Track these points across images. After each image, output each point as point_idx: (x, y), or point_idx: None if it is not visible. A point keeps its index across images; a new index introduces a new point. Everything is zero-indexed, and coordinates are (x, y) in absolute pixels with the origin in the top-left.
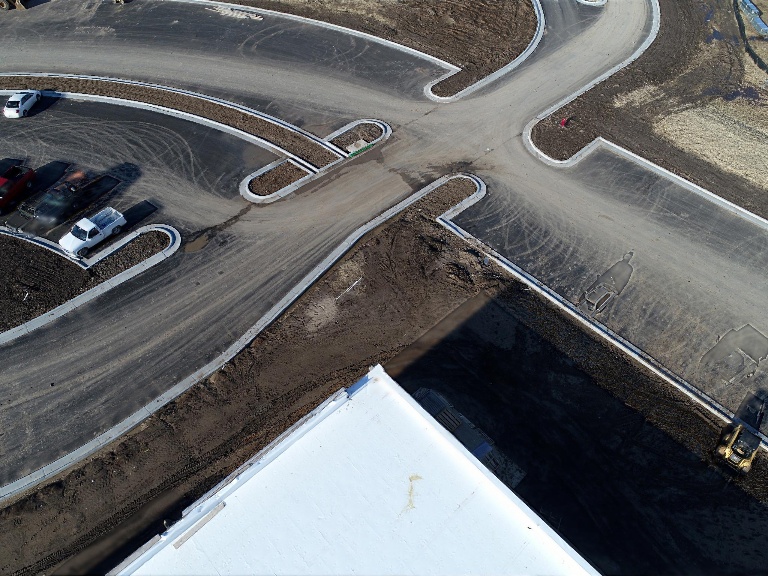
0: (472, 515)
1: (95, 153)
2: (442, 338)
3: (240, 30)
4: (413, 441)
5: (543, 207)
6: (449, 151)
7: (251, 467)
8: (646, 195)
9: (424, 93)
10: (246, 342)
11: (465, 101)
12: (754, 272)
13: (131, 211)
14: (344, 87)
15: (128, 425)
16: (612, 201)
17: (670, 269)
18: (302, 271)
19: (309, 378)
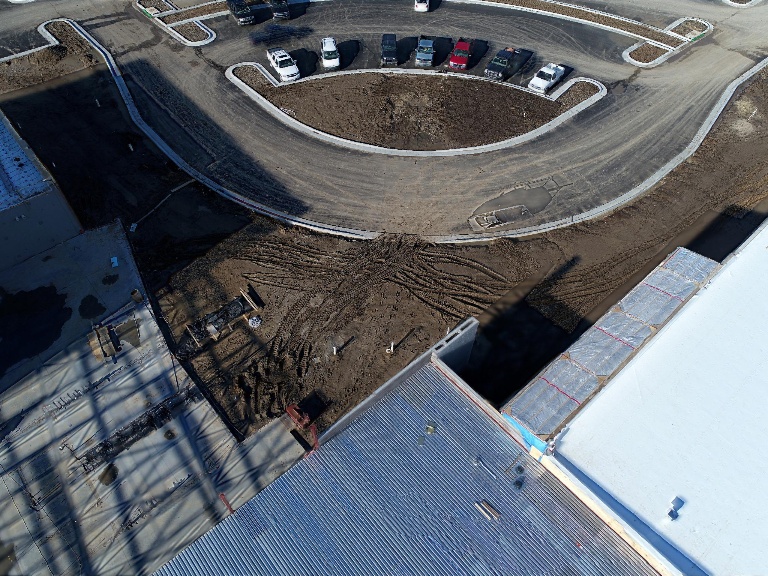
0: None
1: (500, 35)
2: None
3: None
4: None
5: None
6: (767, 38)
7: None
8: None
9: (723, 1)
10: (700, 142)
11: (759, 7)
12: None
13: None
14: None
15: (653, 181)
16: None
17: None
18: (708, 106)
19: (761, 160)
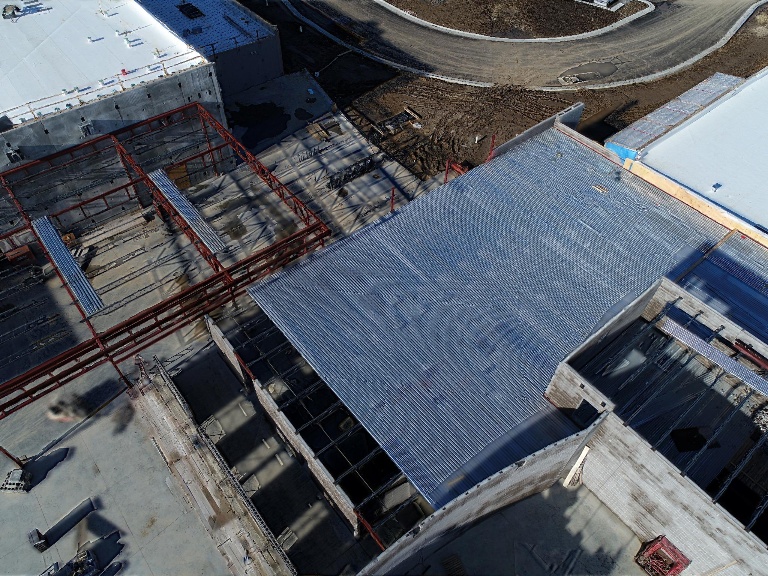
0: None
1: None
2: None
3: None
4: None
5: None
6: None
7: None
8: None
9: None
10: (728, 39)
11: None
12: None
13: None
14: None
15: None
16: None
17: None
18: (734, 18)
19: None
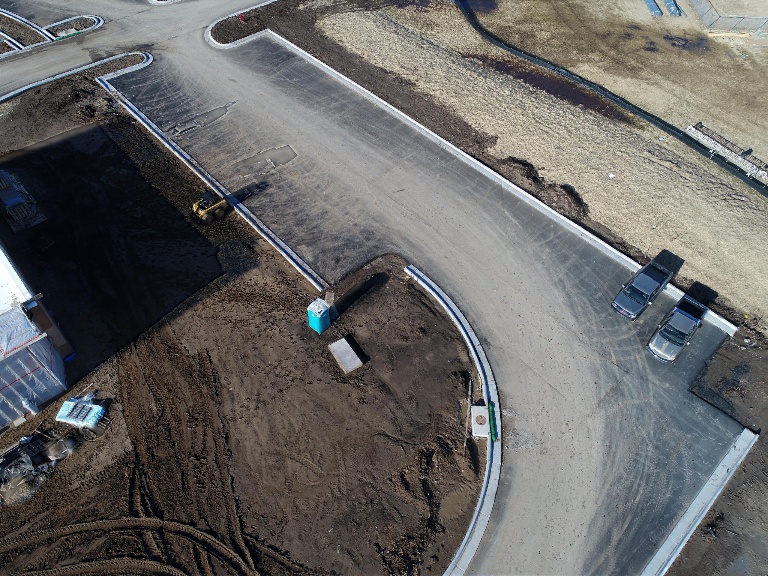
0: None
1: None
2: (43, 147)
3: None
4: None
5: (188, 74)
6: (140, 37)
7: None
8: (275, 67)
9: None
10: None
11: (177, 4)
12: (320, 115)
13: None
14: None
15: None
16: (245, 70)
17: (256, 112)
18: None
19: None
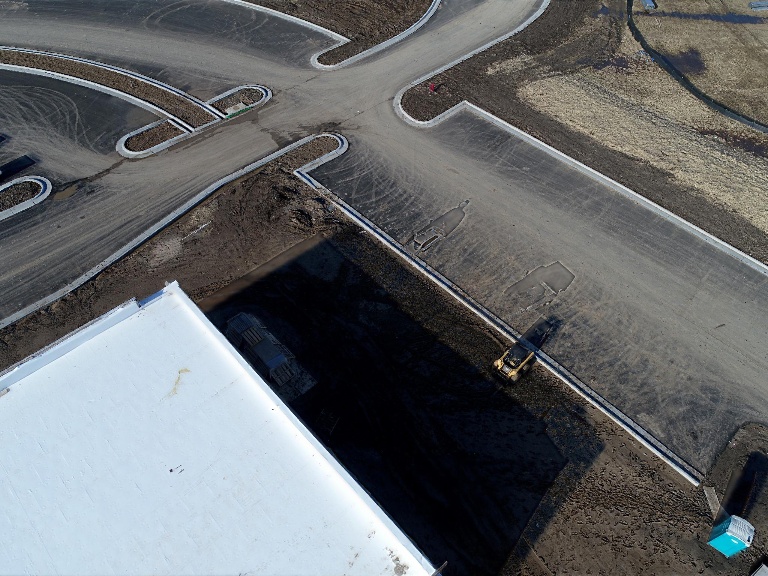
0: (226, 400)
1: None
2: (271, 272)
3: (148, 5)
4: (191, 342)
5: (397, 162)
6: (321, 113)
7: (33, 359)
8: (495, 151)
9: (310, 62)
10: (91, 275)
11: (347, 69)
12: (576, 217)
13: (10, 164)
14: (236, 56)
15: None
16: (462, 157)
17: (499, 215)
18: (158, 216)
19: None
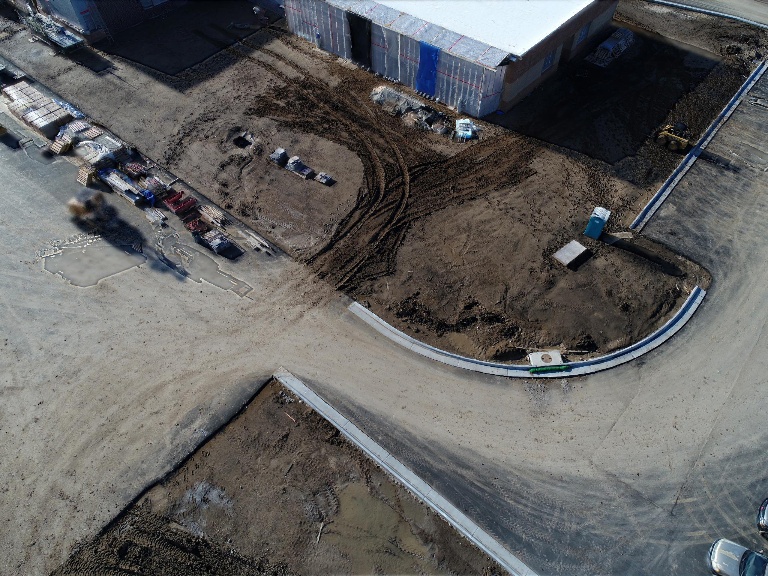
0: (568, 4)
1: None
2: (673, 43)
3: None
4: None
5: None
6: None
7: None
8: None
9: None
10: None
11: None
12: None
13: None
14: None
15: None
16: None
17: None
18: (684, 3)
19: None
